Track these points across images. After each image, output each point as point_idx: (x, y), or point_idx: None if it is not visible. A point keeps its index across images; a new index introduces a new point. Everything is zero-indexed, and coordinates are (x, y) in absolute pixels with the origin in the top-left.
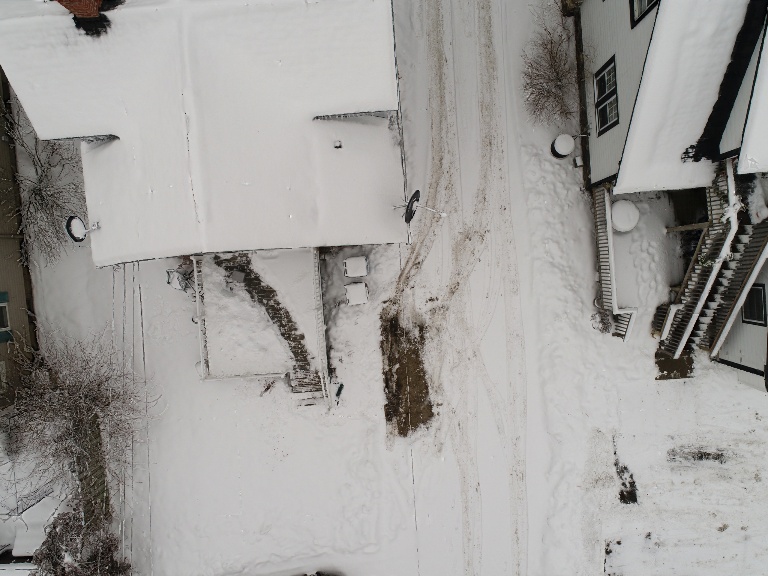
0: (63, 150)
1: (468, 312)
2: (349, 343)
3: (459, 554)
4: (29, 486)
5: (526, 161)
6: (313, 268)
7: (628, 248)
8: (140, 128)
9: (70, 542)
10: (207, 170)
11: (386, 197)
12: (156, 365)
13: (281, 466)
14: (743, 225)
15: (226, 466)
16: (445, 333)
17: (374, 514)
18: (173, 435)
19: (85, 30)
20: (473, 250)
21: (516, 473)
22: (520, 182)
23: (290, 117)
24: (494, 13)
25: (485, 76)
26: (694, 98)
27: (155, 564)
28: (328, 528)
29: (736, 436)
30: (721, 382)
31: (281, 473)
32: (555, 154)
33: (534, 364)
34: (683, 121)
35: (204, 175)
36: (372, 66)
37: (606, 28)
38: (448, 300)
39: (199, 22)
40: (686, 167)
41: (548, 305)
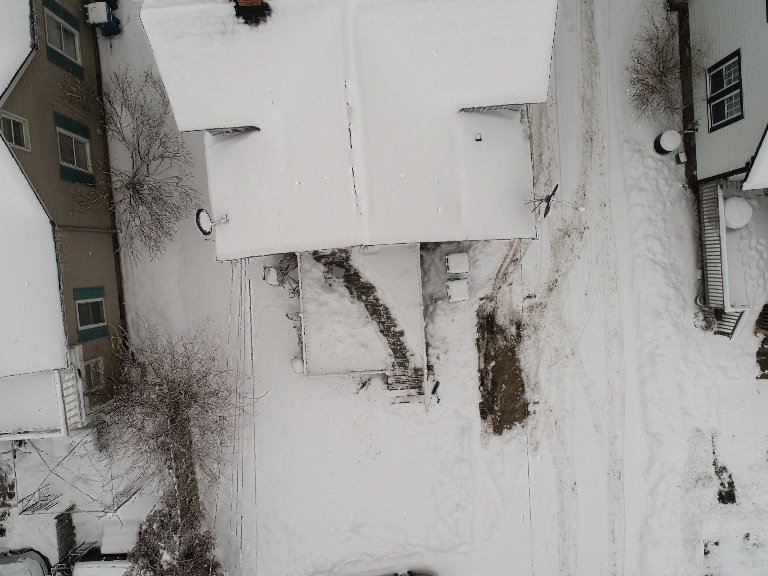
0: (170, 143)
1: (566, 309)
2: (445, 340)
3: (554, 554)
4: (124, 483)
5: (628, 157)
6: (419, 264)
7: (736, 245)
8: (286, 119)
9: (167, 540)
10: (369, 161)
11: (519, 191)
12: (247, 361)
13: (374, 464)
14: None
15: (317, 464)
16: (543, 331)
17: (469, 513)
18: (264, 432)
19: (244, 19)
20: (572, 247)
21: (613, 472)
22: (621, 178)
23: (439, 109)
24: (596, 8)
25: (587, 71)
26: None
27: (244, 562)
28: (420, 527)
29: None
30: None
31: (373, 471)
32: (659, 150)
33: (633, 362)
34: None
35: (367, 166)
36: (529, 57)
37: (727, 22)
38: (546, 297)
39: (363, 11)
40: None
41: (649, 303)
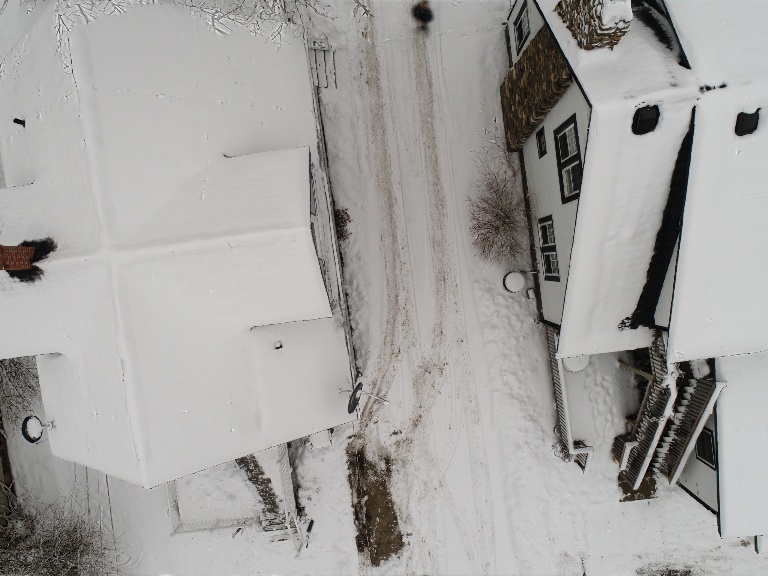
0: None
1: (432, 444)
2: (317, 480)
3: None
4: None
5: (479, 296)
6: None
7: (582, 383)
8: (82, 351)
9: None
10: (144, 410)
11: (331, 383)
12: (130, 507)
13: None
14: (687, 378)
15: None
16: (410, 465)
17: None
18: (151, 574)
19: (19, 278)
20: (433, 383)
21: None
22: (475, 315)
23: (227, 333)
24: (440, 152)
25: (435, 213)
26: (623, 283)
27: None
28: None
29: (702, 553)
30: (684, 502)
31: None
32: (507, 289)
33: (499, 491)
34: (615, 301)
35: (141, 416)
36: (301, 288)
37: (543, 185)
38: (411, 433)
39: (128, 267)
40: (624, 334)
41: (509, 435)
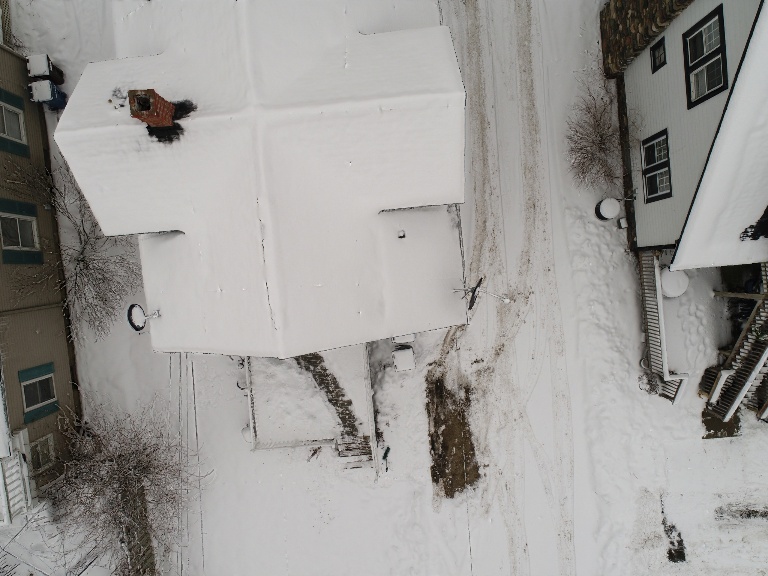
0: None
1: (514, 373)
2: (395, 406)
3: None
4: (77, 556)
5: (570, 223)
6: None
7: (676, 312)
8: (207, 226)
9: None
10: (283, 277)
11: (447, 281)
12: (200, 429)
13: (328, 529)
14: None
15: (272, 529)
16: (491, 395)
17: None
18: (218, 499)
19: (158, 137)
20: (518, 312)
21: (564, 533)
22: (564, 244)
23: (358, 213)
24: (536, 76)
25: (528, 139)
26: (757, 184)
27: None
28: None
29: None
30: None
31: (328, 536)
32: (600, 217)
33: (580, 424)
34: (744, 204)
35: (280, 282)
36: (442, 165)
37: (656, 100)
38: (493, 362)
39: (273, 129)
40: (744, 245)
41: (594, 366)
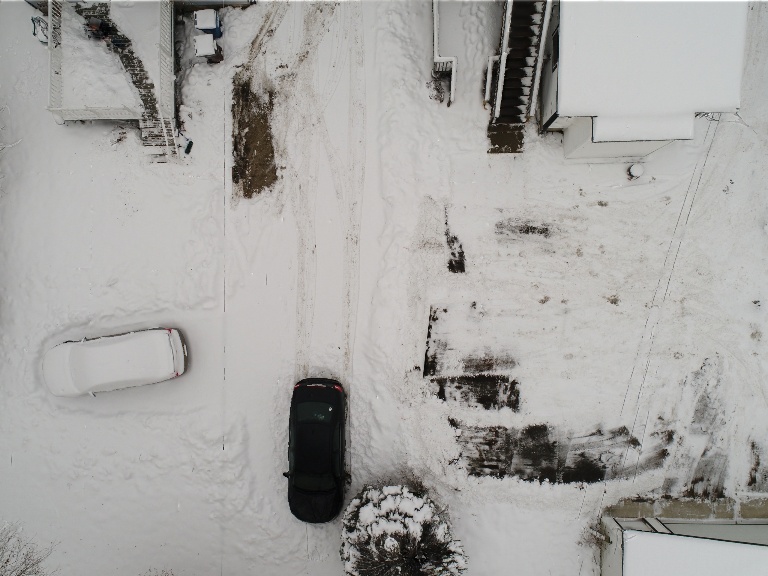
0: None
1: (315, 80)
2: (201, 103)
3: (293, 313)
4: None
5: None
6: (159, 7)
7: (458, 11)
8: None
9: None
10: None
11: None
12: (21, 119)
13: (131, 221)
14: None
15: (80, 220)
16: (292, 99)
17: (213, 268)
18: (32, 188)
19: None
20: (323, 21)
21: (351, 237)
22: None
23: None
24: None
25: None
26: None
27: (5, 312)
28: (171, 284)
29: (561, 211)
30: (548, 157)
31: (130, 228)
32: None
33: (374, 132)
34: None
35: None
36: None
37: None
38: (297, 68)
39: None
40: None
41: (388, 73)
